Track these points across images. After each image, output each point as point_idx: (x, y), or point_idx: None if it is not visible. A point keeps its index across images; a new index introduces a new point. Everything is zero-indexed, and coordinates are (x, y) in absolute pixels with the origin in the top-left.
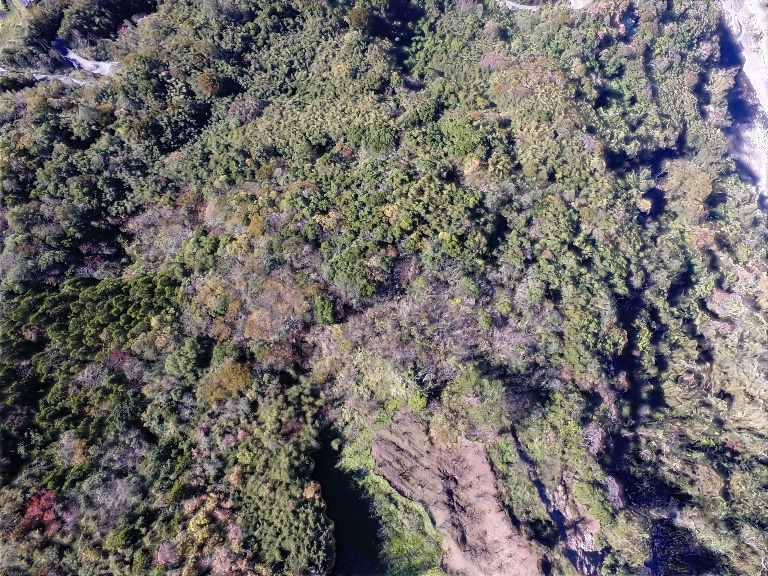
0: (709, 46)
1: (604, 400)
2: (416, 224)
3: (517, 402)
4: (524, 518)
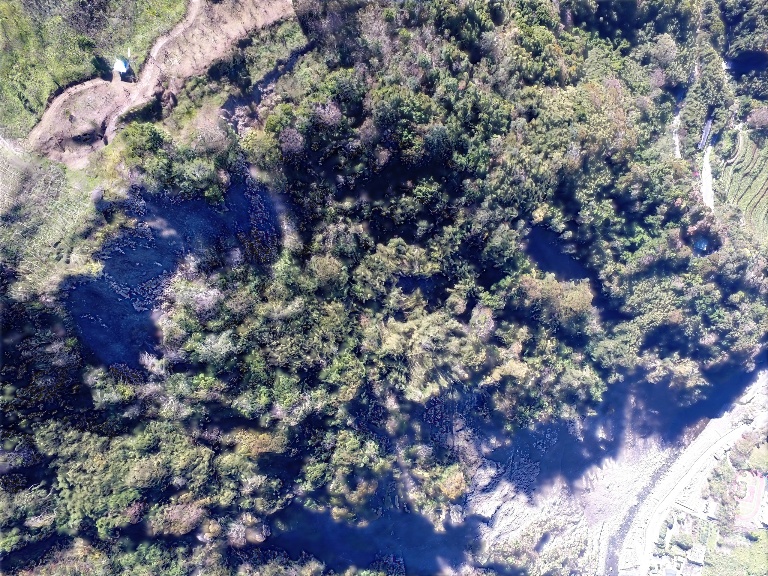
0: (713, 339)
1: (361, 127)
2: None
3: (334, 48)
4: (247, 55)
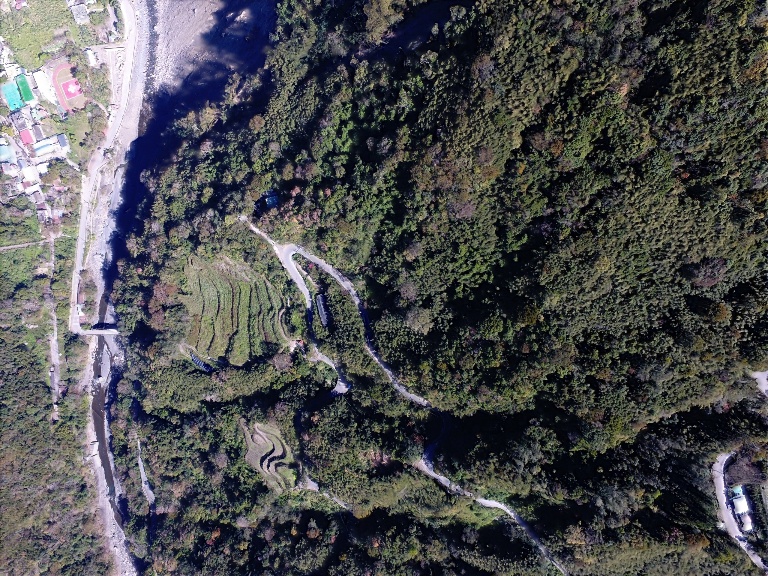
0: (204, 148)
1: None
2: (754, 43)
3: None
4: None
